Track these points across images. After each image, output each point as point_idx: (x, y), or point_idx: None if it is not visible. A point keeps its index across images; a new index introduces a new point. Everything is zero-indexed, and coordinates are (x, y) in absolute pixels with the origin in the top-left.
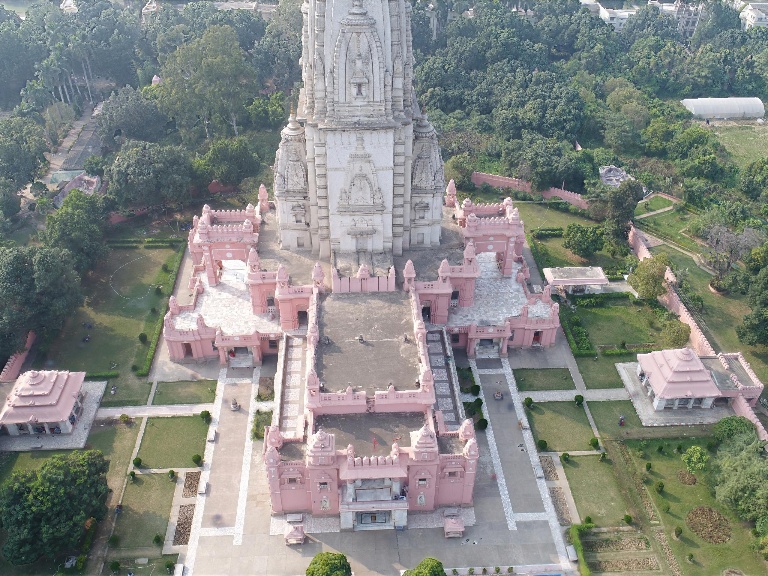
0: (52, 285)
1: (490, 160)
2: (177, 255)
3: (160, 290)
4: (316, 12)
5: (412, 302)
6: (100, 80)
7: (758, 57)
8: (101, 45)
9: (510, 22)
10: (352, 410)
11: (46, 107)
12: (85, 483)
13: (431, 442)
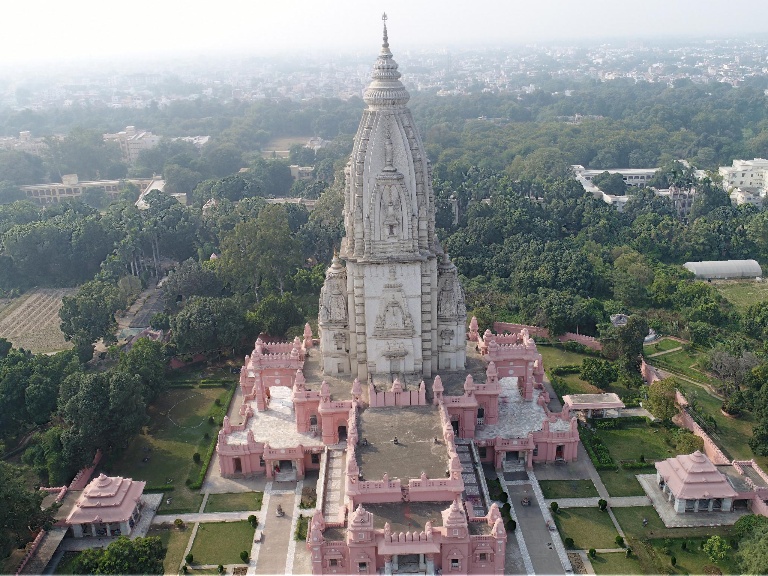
0: (124, 403)
1: (510, 314)
2: (228, 393)
3: (213, 420)
4: (356, 171)
5: (441, 412)
6: (164, 262)
7: (748, 226)
8: (169, 230)
9: (523, 205)
10: (388, 499)
11: (120, 277)
12: (146, 562)
13: (461, 517)
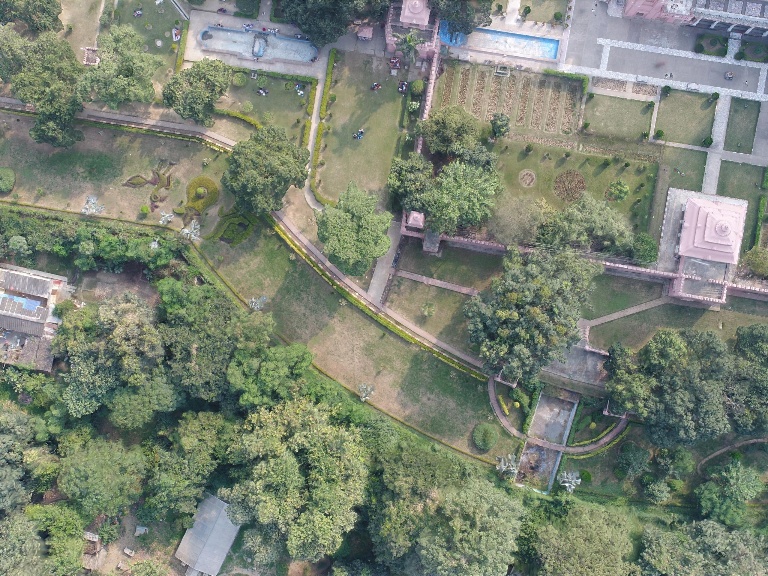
0: None
1: None
2: None
3: None
4: None
5: None
6: None
7: None
8: None
9: None
10: None
11: None
12: None
13: None
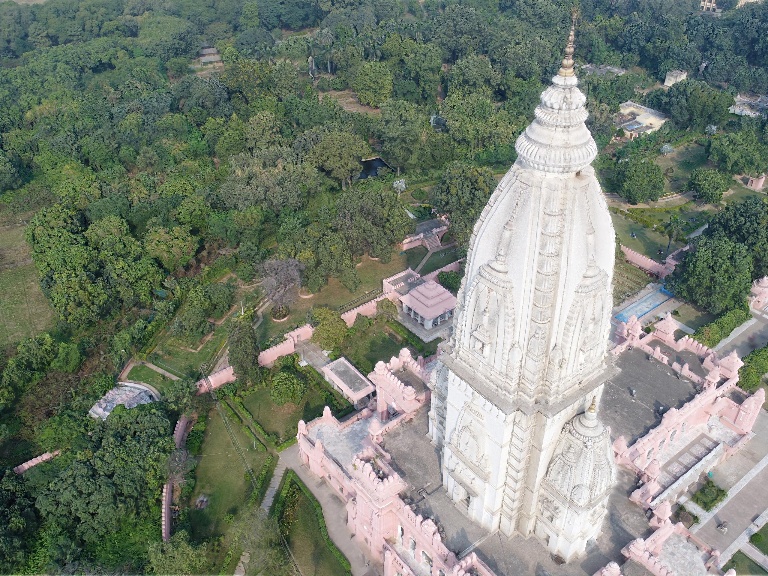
0: None
1: (90, 561)
2: None
3: None
4: None
5: None
6: None
7: None
8: None
9: None
10: None
11: None
12: None
13: None
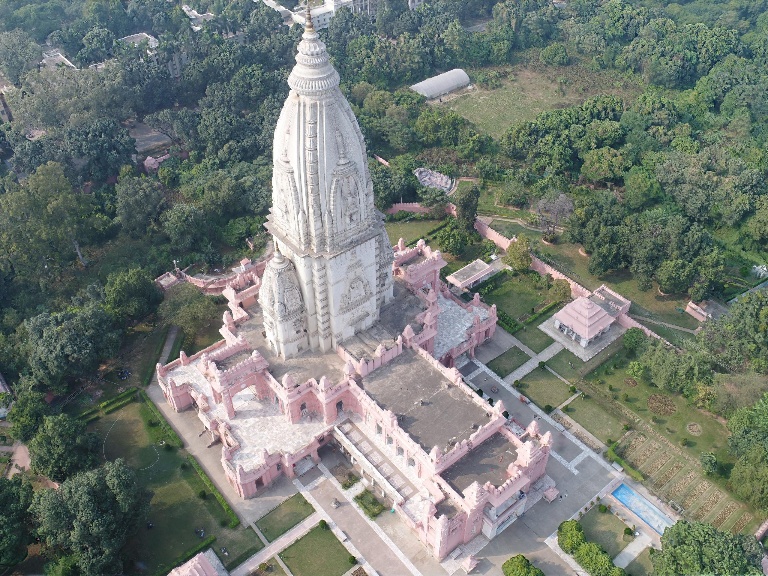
0: None
1: None
2: (146, 406)
3: (169, 446)
4: (310, 172)
5: (426, 355)
6: None
7: (445, 35)
8: None
9: (242, 54)
10: (459, 457)
11: None
12: None
13: (537, 450)
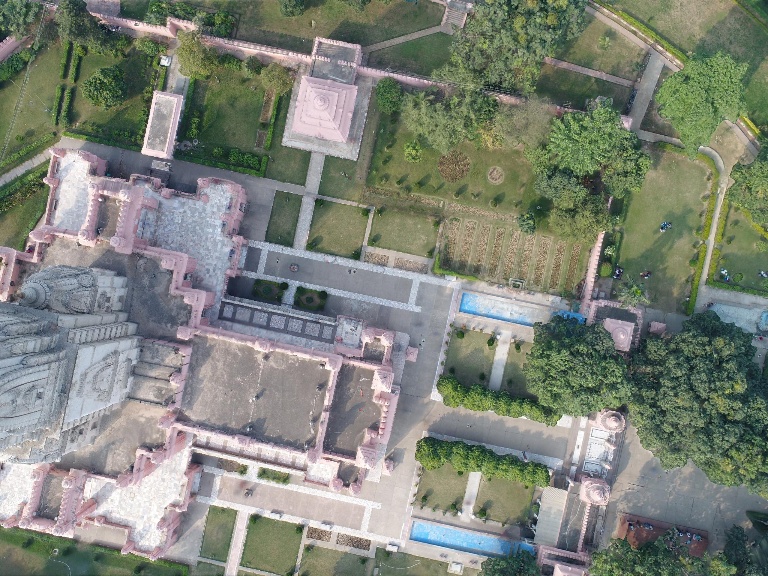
0: None
1: None
2: (2, 531)
3: (65, 552)
4: None
5: None
6: None
7: None
8: None
9: None
10: None
11: None
12: None
13: (390, 379)
